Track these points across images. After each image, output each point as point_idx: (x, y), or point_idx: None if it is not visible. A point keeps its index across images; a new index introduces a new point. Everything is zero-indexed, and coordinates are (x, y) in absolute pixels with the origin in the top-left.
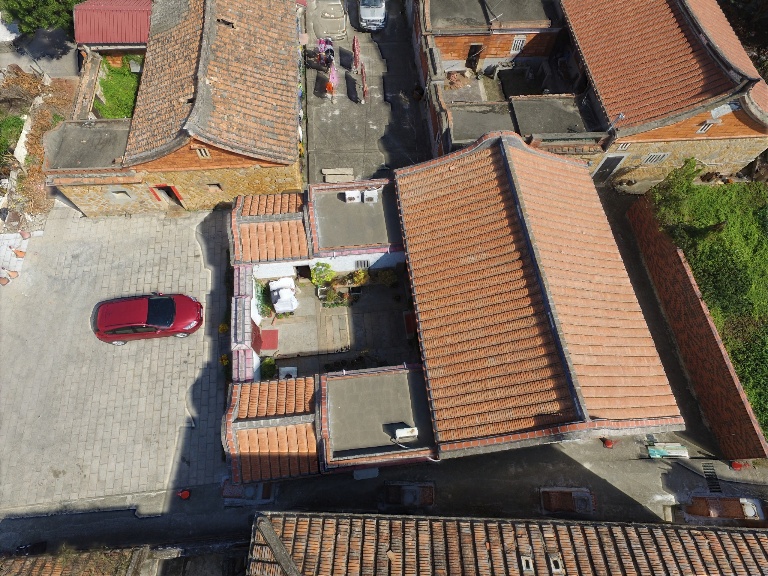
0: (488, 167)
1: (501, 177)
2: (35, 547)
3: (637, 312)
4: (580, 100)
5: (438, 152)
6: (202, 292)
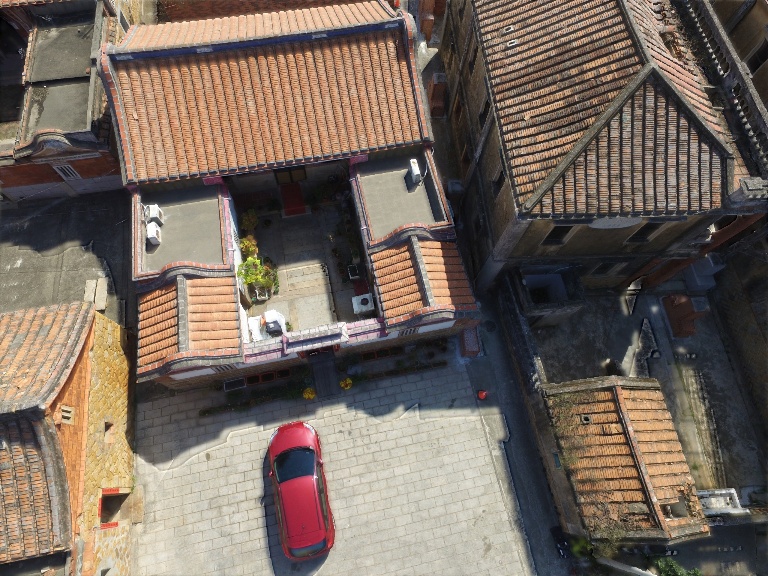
0: (143, 78)
1: (159, 65)
2: (558, 538)
3: (295, 12)
4: (42, 25)
5: (83, 176)
6: (260, 436)
